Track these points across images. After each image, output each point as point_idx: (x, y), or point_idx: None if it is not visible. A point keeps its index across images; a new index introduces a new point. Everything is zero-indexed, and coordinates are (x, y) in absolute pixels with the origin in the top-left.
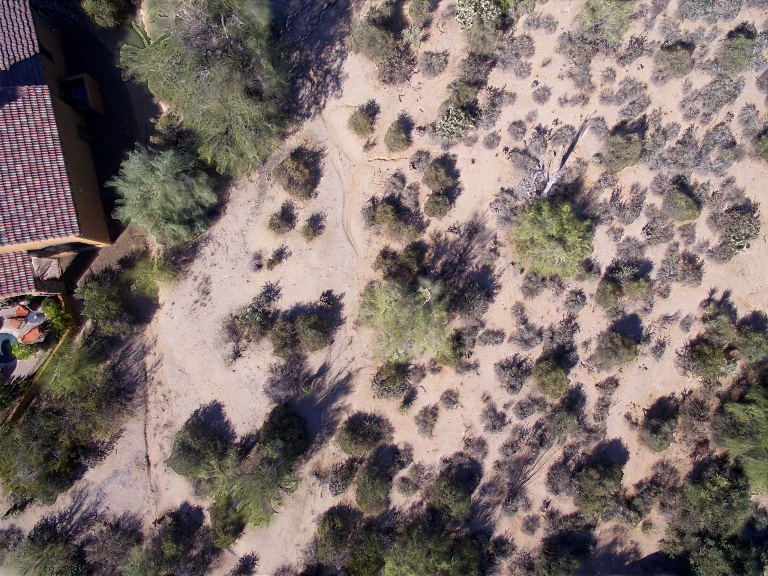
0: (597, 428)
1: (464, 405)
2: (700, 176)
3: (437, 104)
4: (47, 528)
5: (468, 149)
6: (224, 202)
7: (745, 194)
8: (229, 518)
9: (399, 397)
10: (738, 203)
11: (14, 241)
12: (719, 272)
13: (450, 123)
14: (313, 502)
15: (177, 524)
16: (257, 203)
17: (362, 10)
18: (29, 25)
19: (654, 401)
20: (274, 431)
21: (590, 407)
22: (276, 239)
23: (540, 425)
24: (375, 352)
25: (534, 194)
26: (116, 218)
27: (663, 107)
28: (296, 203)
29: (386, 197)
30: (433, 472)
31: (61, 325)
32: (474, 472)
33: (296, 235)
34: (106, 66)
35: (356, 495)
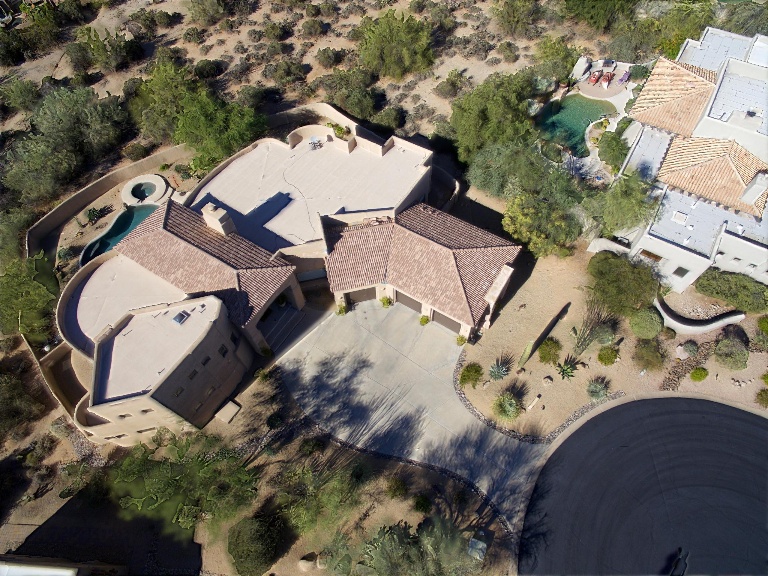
0: None
1: (228, 45)
2: None
3: None
4: None
5: None
6: None
7: None
8: None
9: None
10: None
11: None
12: (375, 13)
13: None
14: None
15: None
16: None
17: None
18: None
19: None
20: None
21: (296, 52)
22: None
23: None
24: None
25: None
26: None
27: None
28: None
29: None
30: None
31: None
32: None
33: None
34: None
35: None
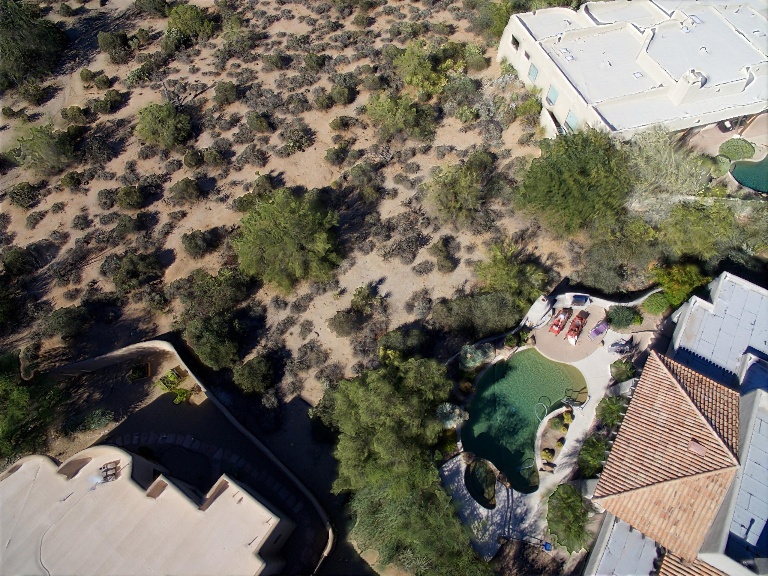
0: (159, 240)
1: (67, 212)
2: (281, 115)
3: None
4: None
5: (141, 89)
6: None
7: (309, 126)
8: None
9: (26, 204)
10: (300, 128)
11: None
12: (280, 162)
13: None
14: None
15: None
16: None
17: None
18: None
19: (209, 229)
20: None
21: (160, 227)
22: (5, 121)
23: (115, 230)
24: (29, 182)
25: None
26: None
27: (265, 81)
28: (29, 107)
29: (84, 109)
30: None
31: None
32: None
33: (19, 120)
34: None
35: None
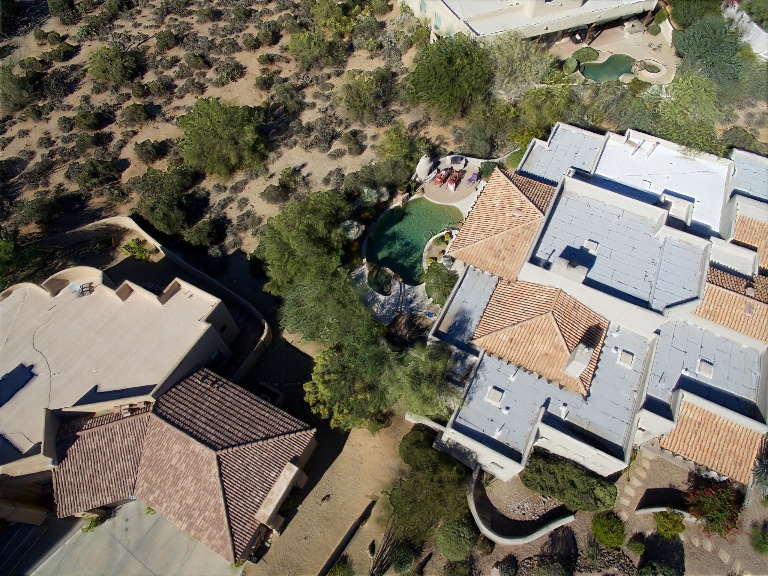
0: None
1: (32, 136)
2: (215, 56)
3: None
4: None
5: (90, 42)
6: None
7: (240, 63)
8: None
9: None
10: (232, 64)
11: None
12: (216, 91)
13: None
14: None
15: None
16: None
17: None
18: None
19: None
20: None
21: (114, 143)
22: None
23: None
24: None
25: None
26: None
27: (200, 31)
28: None
29: (40, 60)
30: None
31: None
32: None
33: None
34: None
35: None
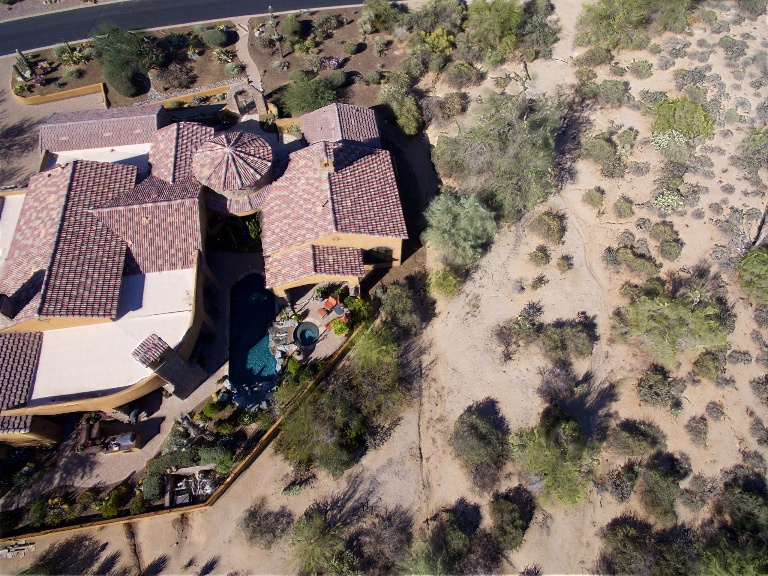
0: None
1: (731, 417)
2: None
3: (648, 191)
4: (318, 514)
5: (681, 218)
6: (489, 243)
7: None
8: (517, 512)
9: (666, 405)
10: None
11: (368, 232)
12: None
13: (667, 198)
14: (593, 512)
15: (454, 521)
16: (515, 246)
17: (582, 137)
18: (374, 123)
19: None
20: (557, 421)
21: None
22: (535, 270)
23: None
24: (632, 365)
25: (744, 250)
26: (421, 238)
27: None
28: (548, 246)
29: (620, 247)
30: (716, 485)
31: (366, 313)
32: (761, 487)
33: (551, 268)
34: (400, 158)
35: (641, 504)
